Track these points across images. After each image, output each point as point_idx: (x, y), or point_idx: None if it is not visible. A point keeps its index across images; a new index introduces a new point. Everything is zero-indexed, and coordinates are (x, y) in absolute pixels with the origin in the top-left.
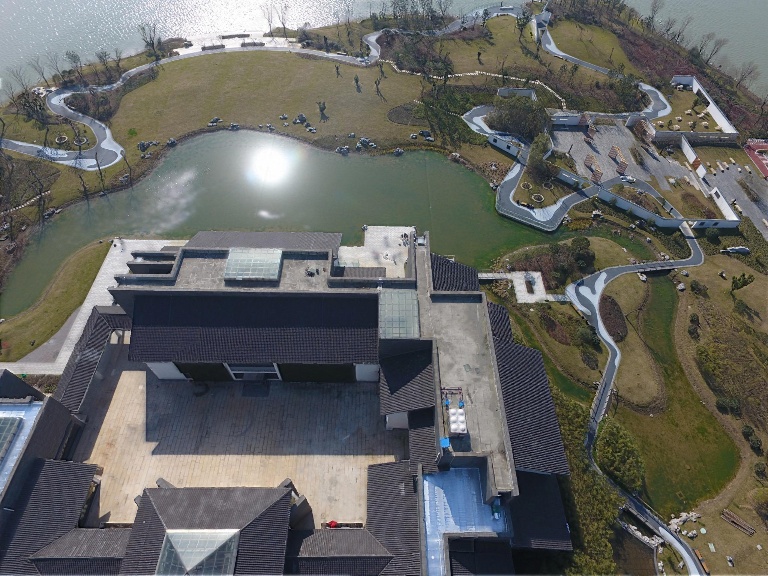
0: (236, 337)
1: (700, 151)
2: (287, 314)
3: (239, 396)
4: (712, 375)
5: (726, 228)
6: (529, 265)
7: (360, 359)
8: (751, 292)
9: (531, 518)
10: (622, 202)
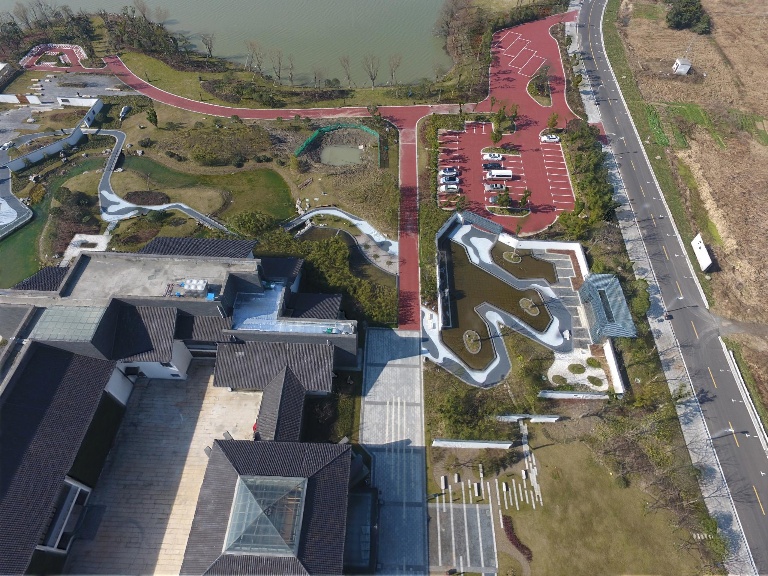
0: (8, 520)
1: (9, 92)
2: (7, 449)
3: (92, 544)
4: (215, 159)
5: (101, 110)
6: (63, 240)
7: (104, 378)
8: (163, 119)
9: (279, 272)
10: (33, 156)
